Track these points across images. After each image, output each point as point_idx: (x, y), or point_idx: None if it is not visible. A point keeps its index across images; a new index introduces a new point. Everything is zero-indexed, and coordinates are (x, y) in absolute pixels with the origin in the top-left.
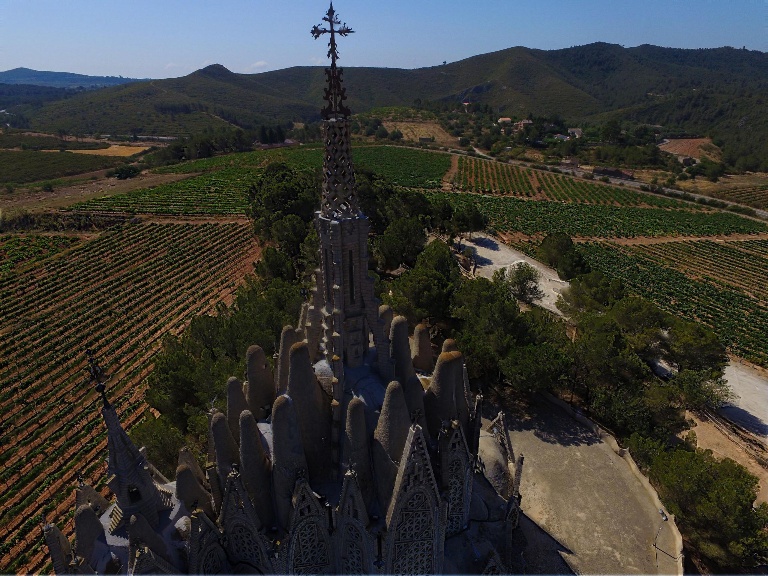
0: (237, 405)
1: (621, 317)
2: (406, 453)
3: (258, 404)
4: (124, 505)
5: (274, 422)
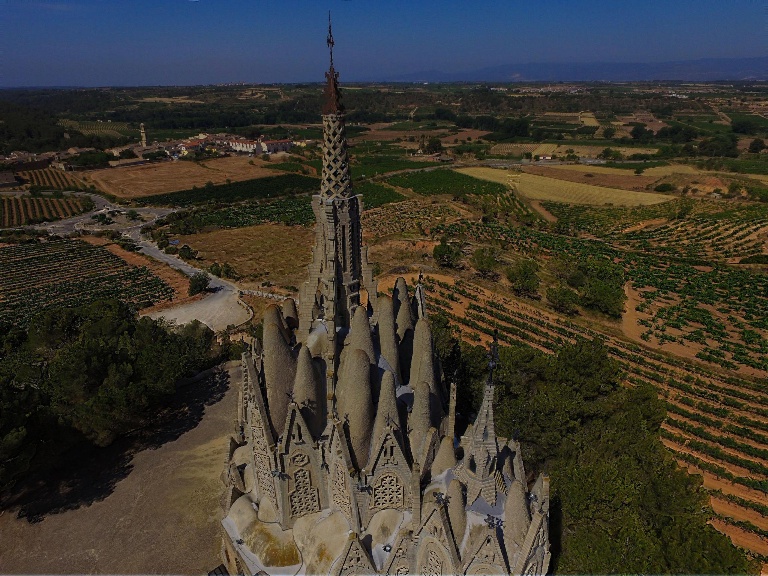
0: None
1: (44, 338)
2: None
3: (371, 399)
4: None
5: None
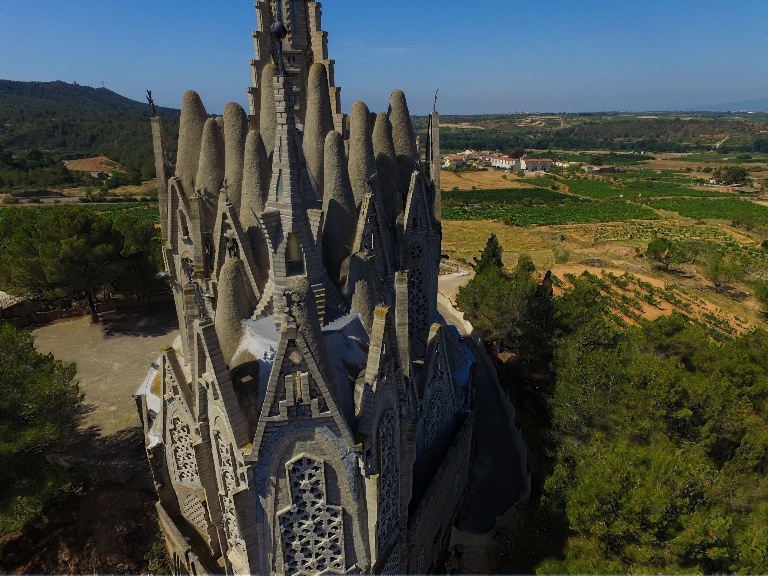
0: (269, 171)
1: None
2: (436, 139)
3: None
4: (319, 270)
5: (367, 129)
